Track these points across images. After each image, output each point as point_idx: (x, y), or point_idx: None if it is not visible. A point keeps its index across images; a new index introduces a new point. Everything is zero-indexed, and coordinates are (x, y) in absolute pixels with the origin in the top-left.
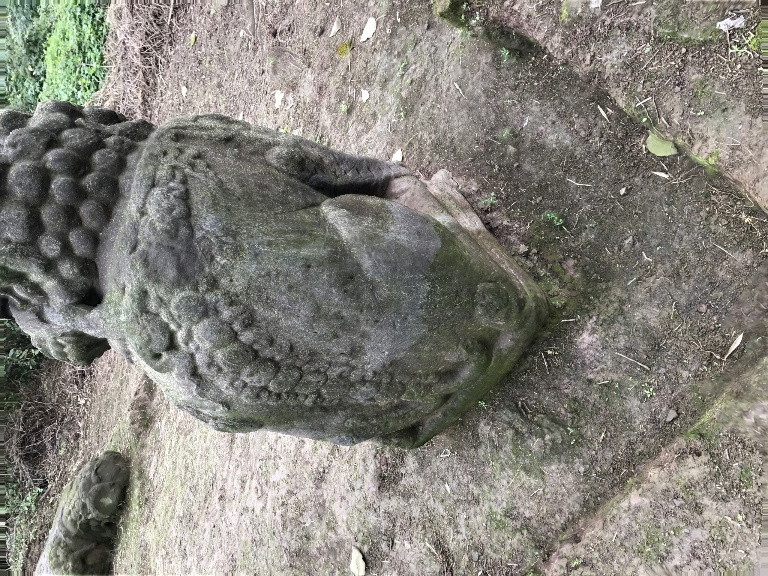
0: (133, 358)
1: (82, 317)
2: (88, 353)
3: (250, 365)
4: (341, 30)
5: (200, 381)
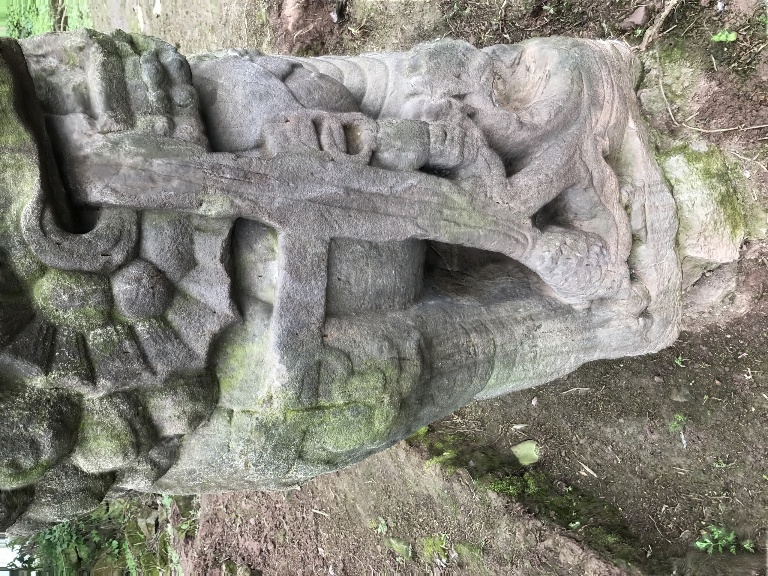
0: None
1: None
2: None
3: None
4: None
5: None
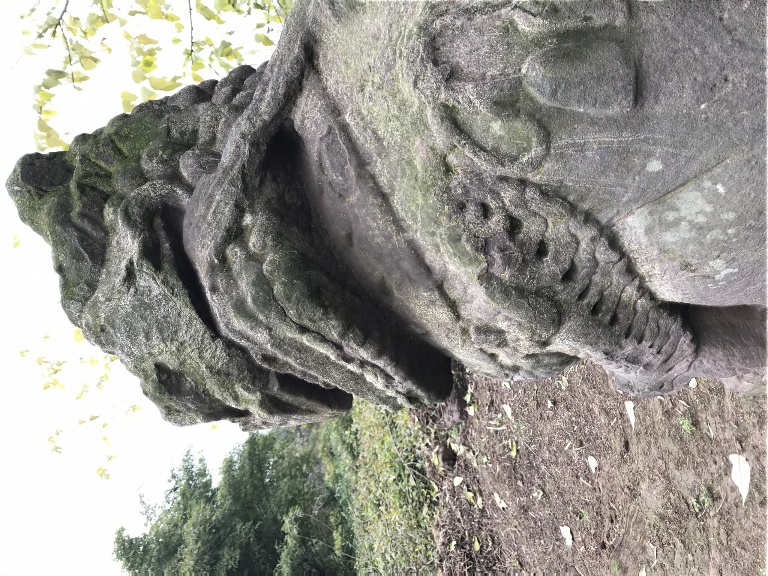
0: (346, 115)
1: None
2: (306, 272)
3: None
4: (635, 403)
5: None
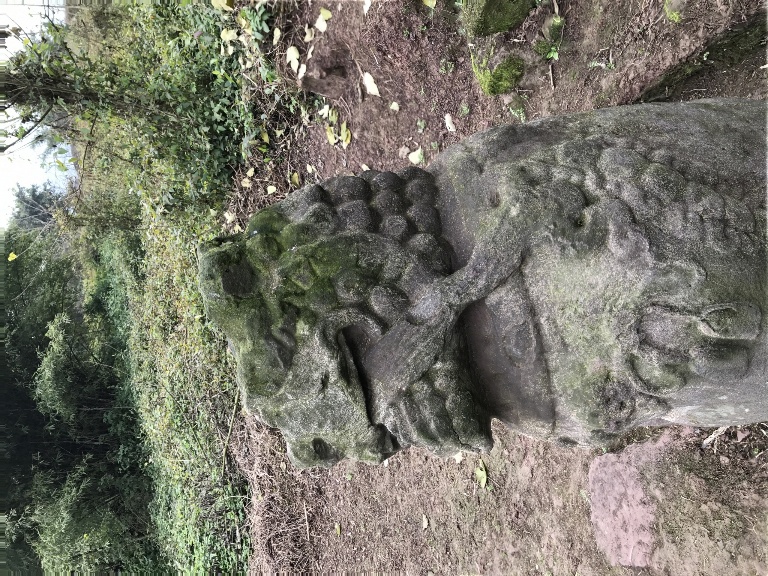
0: (542, 318)
1: (463, 271)
2: (475, 408)
3: (688, 186)
4: None
5: (648, 232)
